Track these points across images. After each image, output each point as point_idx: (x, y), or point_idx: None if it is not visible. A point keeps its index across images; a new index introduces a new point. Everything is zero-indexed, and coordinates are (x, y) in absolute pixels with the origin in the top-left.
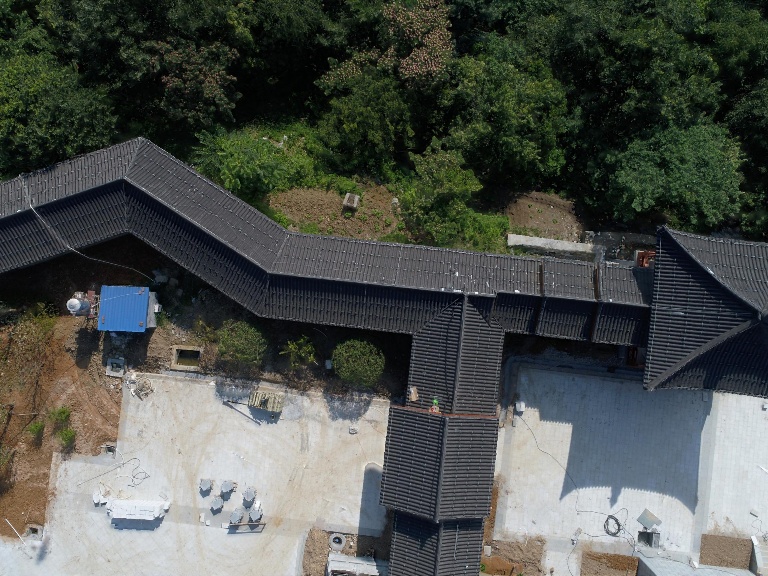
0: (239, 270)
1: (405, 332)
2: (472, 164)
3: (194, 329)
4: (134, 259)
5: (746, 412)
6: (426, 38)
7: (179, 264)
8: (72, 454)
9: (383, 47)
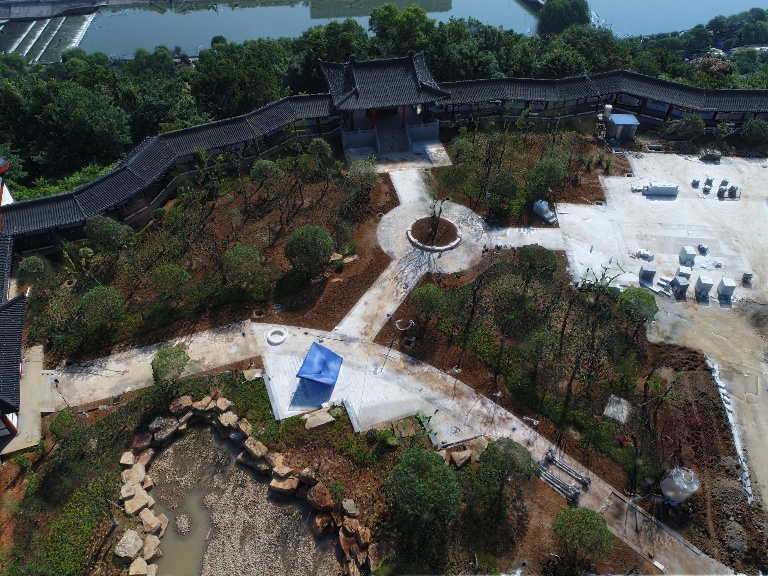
0: (687, 94)
1: None
2: None
3: (653, 140)
4: None
5: None
6: None
7: (653, 98)
8: (609, 176)
9: None
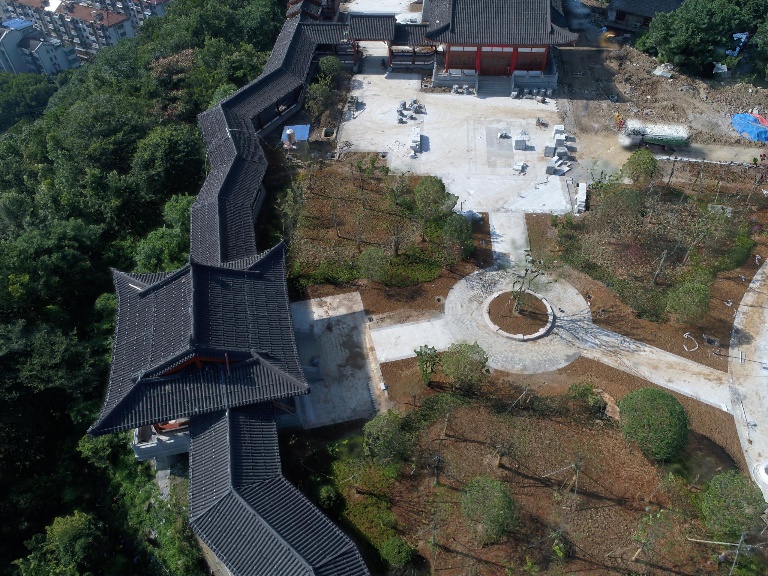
0: (278, 80)
1: (315, 45)
2: (239, 78)
3: (312, 131)
4: (268, 153)
5: (359, 6)
6: (174, 60)
7: (272, 103)
8: None
9: (171, 86)
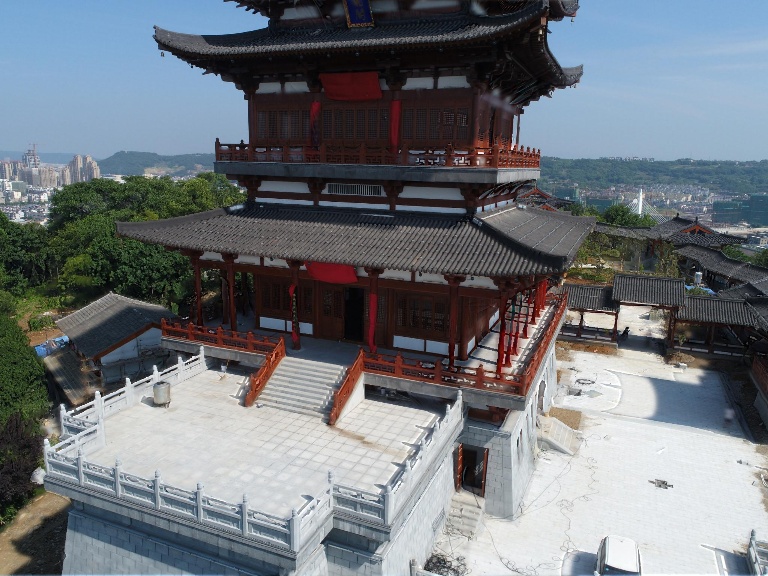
0: None
1: None
2: None
3: None
4: None
5: None
6: None
7: None
8: None
9: None
